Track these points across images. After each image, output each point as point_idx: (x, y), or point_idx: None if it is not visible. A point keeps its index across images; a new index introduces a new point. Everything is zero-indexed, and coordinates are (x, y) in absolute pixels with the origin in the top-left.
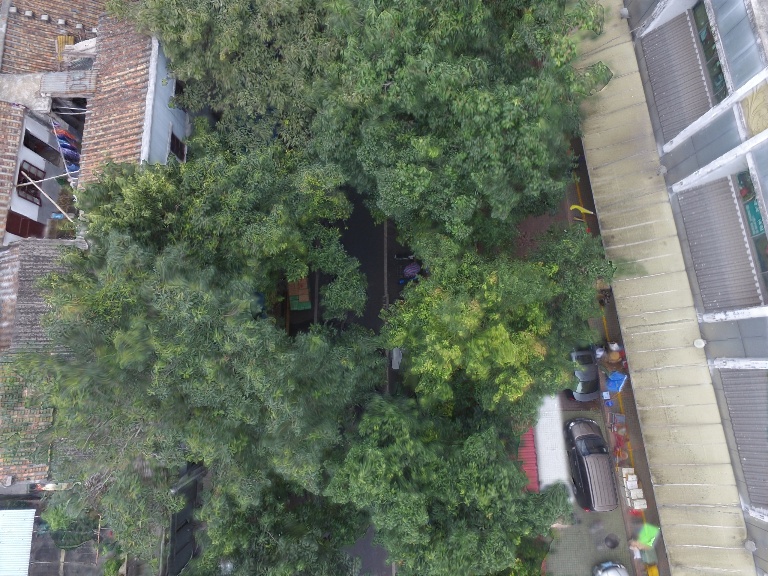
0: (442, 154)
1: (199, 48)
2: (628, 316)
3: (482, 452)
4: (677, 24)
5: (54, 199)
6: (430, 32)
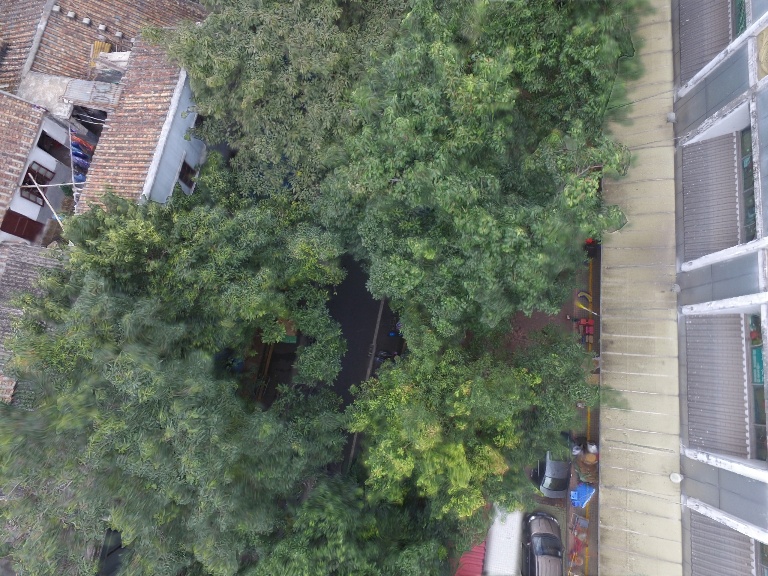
0: (440, 252)
1: (225, 87)
2: (610, 428)
3: (415, 570)
4: (722, 143)
5: (59, 199)
6: (446, 143)
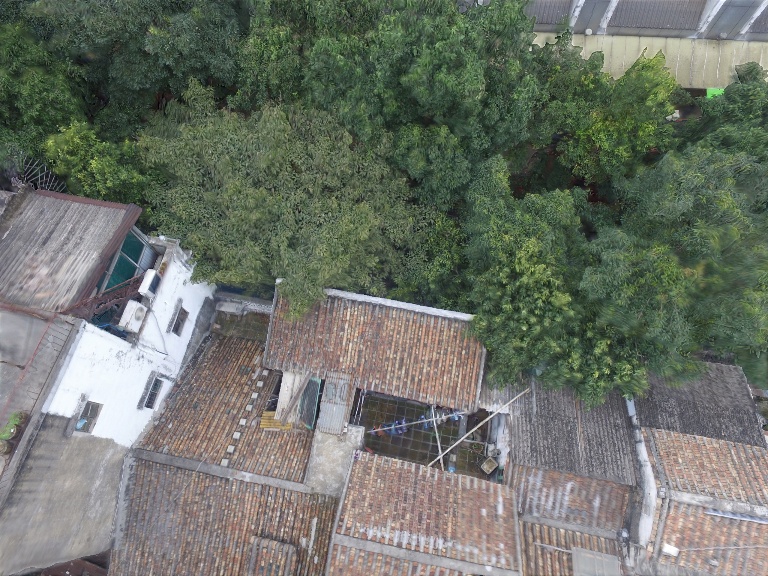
0: None
1: None
2: None
3: (722, 100)
4: None
5: None
6: (457, 21)
